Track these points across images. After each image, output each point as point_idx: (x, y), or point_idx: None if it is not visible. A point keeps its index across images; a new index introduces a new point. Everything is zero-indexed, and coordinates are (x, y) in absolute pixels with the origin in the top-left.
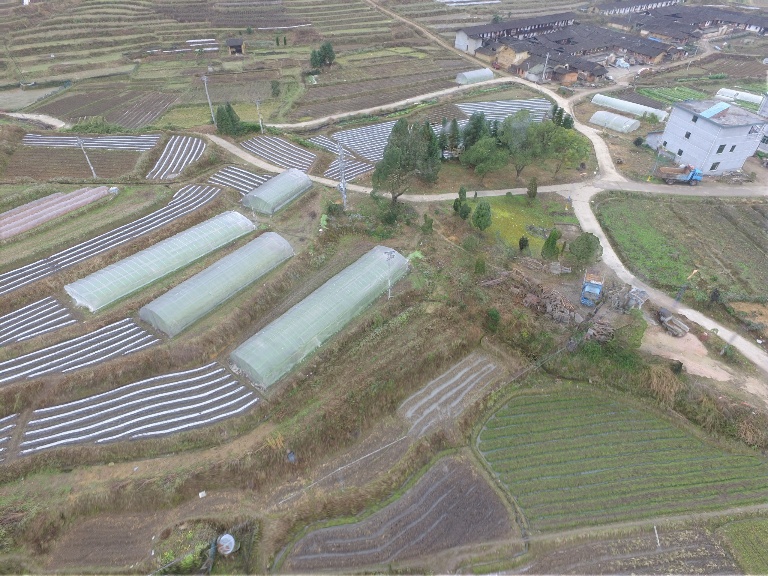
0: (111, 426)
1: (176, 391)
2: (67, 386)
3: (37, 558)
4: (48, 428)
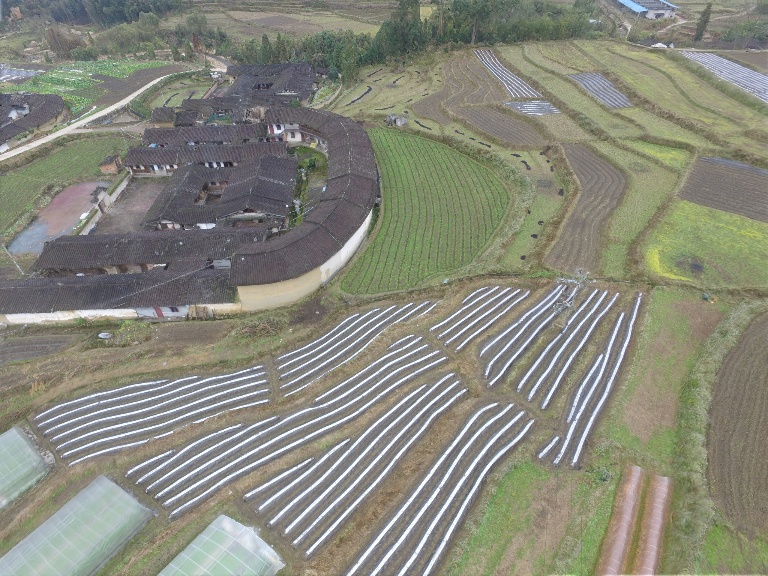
0: (189, 391)
1: (122, 425)
2: (231, 410)
3: (232, 324)
4: (247, 385)
